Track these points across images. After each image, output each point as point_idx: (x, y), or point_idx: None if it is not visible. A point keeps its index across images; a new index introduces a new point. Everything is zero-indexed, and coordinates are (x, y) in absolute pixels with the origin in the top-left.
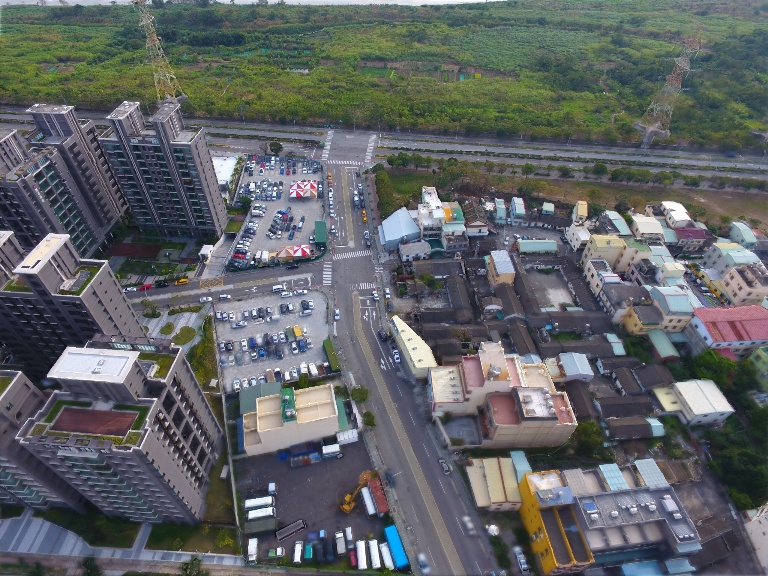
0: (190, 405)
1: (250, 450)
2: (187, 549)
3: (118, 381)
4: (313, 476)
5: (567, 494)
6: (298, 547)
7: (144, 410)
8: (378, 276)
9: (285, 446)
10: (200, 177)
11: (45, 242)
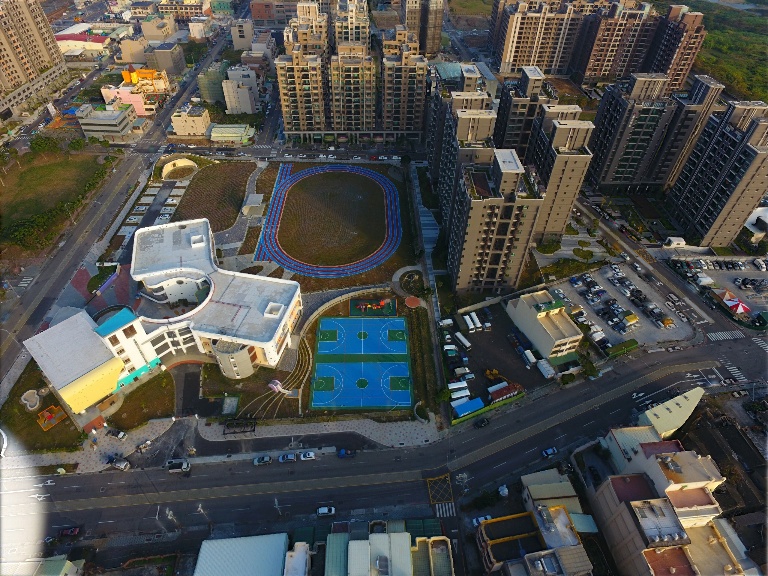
0: (516, 236)
1: (509, 307)
2: (439, 293)
3: (502, 169)
4: (505, 351)
5: (555, 541)
6: (453, 346)
7: (495, 197)
8: (761, 383)
9: (521, 329)
10: (738, 185)
11: (582, 122)
